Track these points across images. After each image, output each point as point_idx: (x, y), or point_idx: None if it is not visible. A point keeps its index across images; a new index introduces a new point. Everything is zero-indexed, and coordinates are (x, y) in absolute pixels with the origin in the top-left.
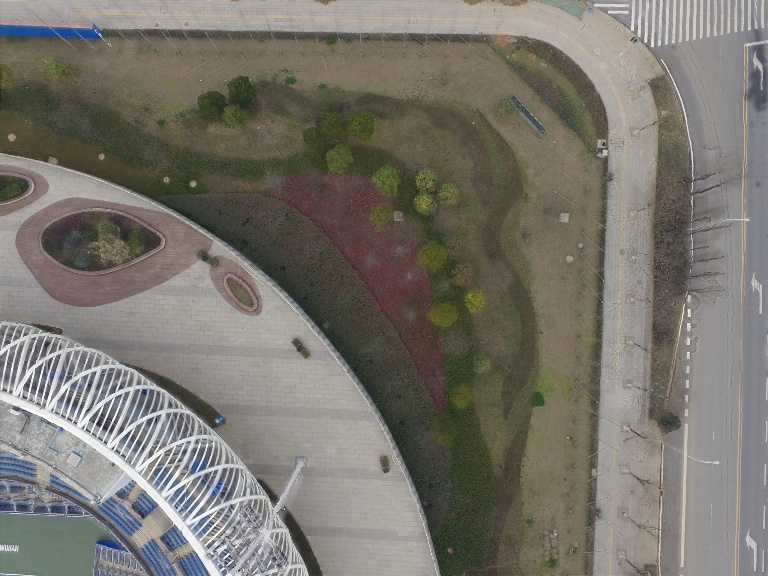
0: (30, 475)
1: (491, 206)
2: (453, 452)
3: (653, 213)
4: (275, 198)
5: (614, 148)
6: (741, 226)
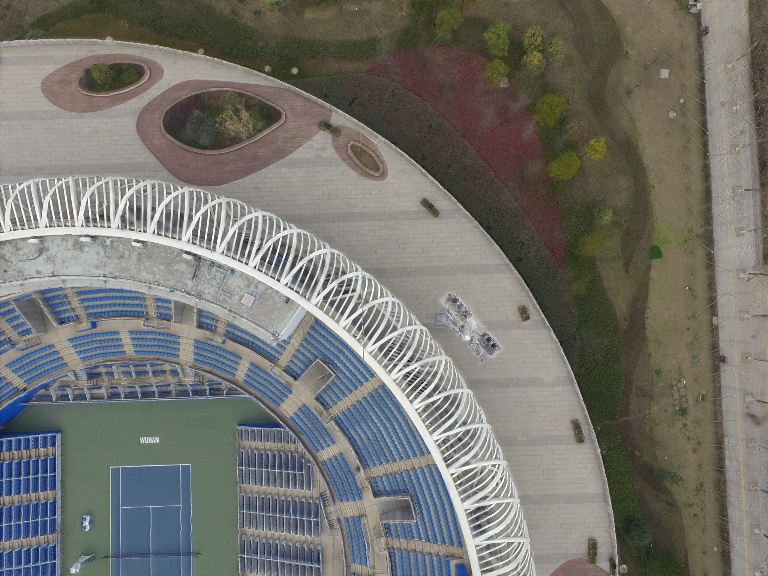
0: (173, 356)
1: (594, 65)
2: (579, 308)
3: (749, 64)
4: (379, 76)
5: (706, 3)
6: None
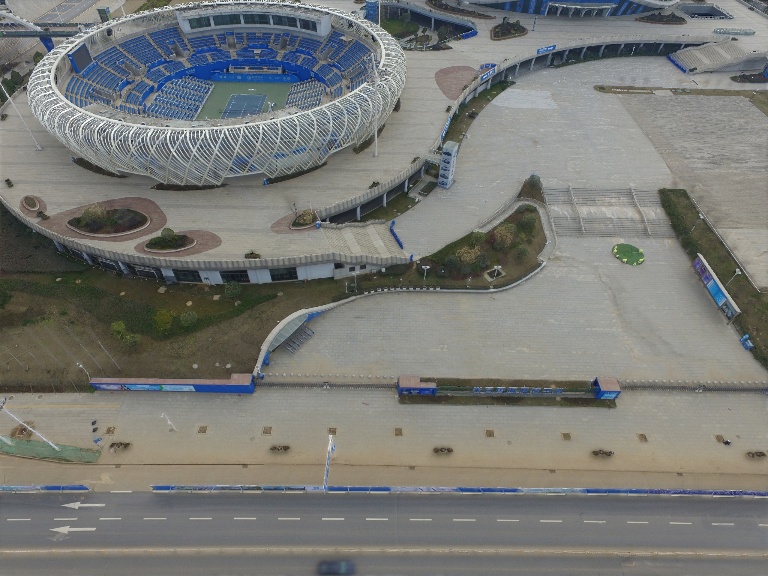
0: None
1: None
2: None
3: None
4: None
5: None
6: None
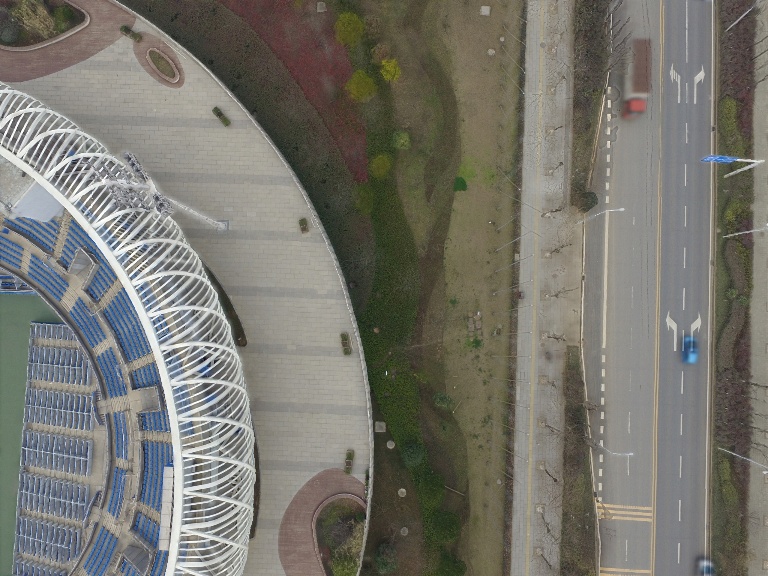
0: None
1: None
2: (377, 233)
3: (573, 8)
4: None
5: None
6: (660, 20)
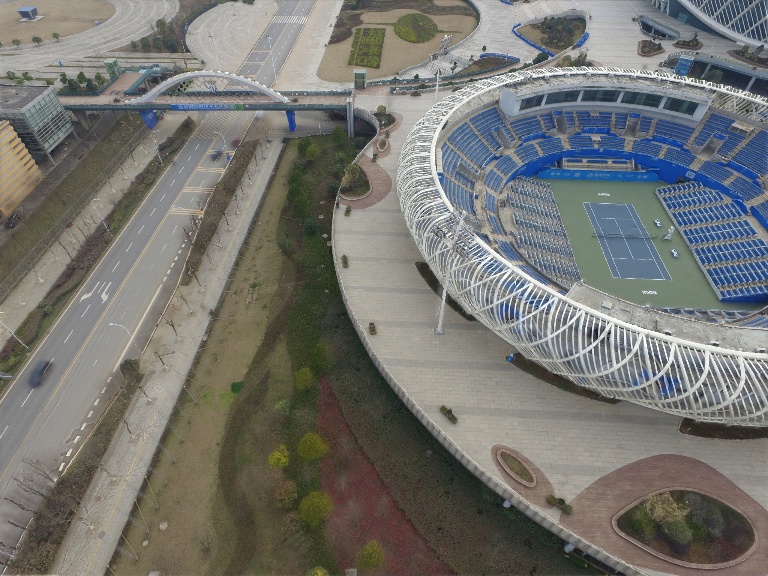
0: None
1: None
2: None
3: None
4: None
5: None
6: None
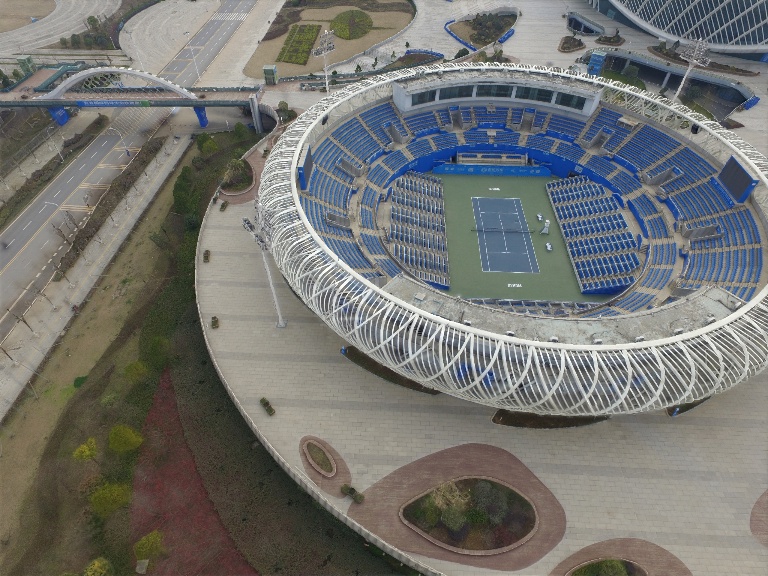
0: None
1: None
2: None
3: None
4: None
5: None
6: None
